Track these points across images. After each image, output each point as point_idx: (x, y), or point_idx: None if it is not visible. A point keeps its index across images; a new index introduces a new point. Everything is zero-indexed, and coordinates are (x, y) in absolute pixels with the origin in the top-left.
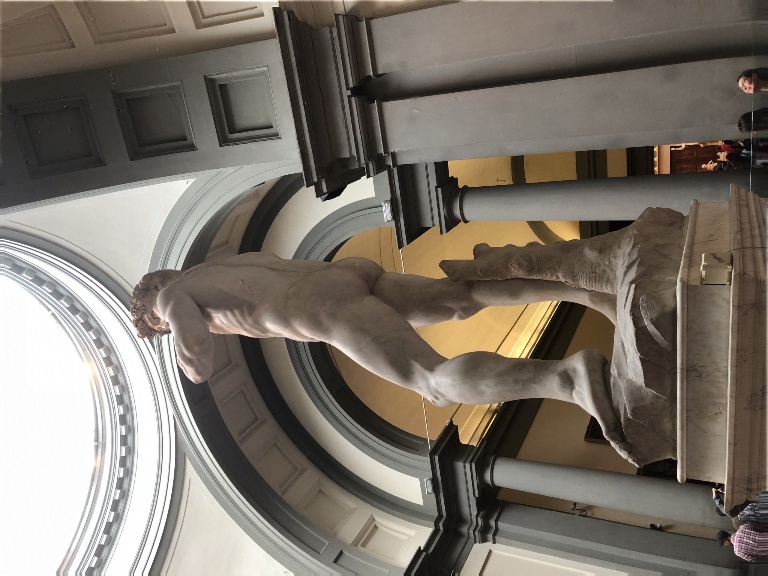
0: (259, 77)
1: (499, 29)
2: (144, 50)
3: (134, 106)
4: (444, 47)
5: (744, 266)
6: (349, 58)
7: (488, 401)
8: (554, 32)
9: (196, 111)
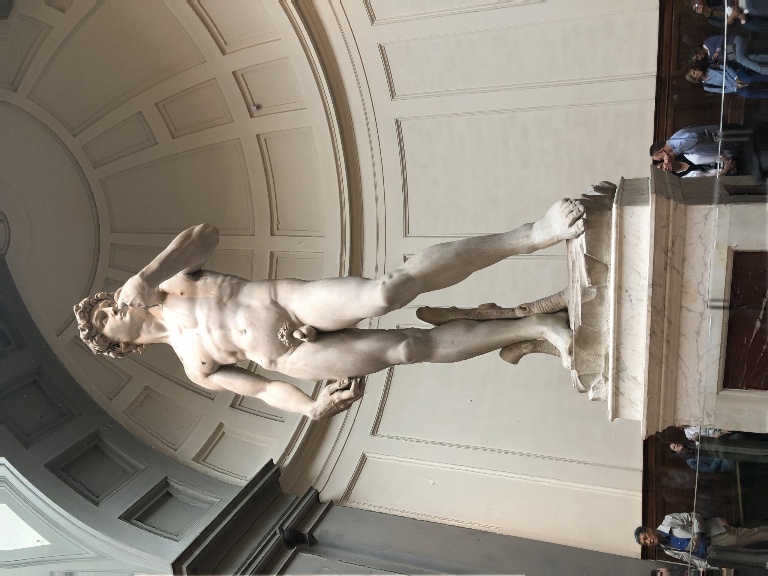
0: (204, 505)
1: (436, 543)
2: (145, 439)
3: (93, 453)
4: (383, 538)
5: None
6: (299, 512)
7: (450, 252)
8: (482, 558)
9: (132, 487)
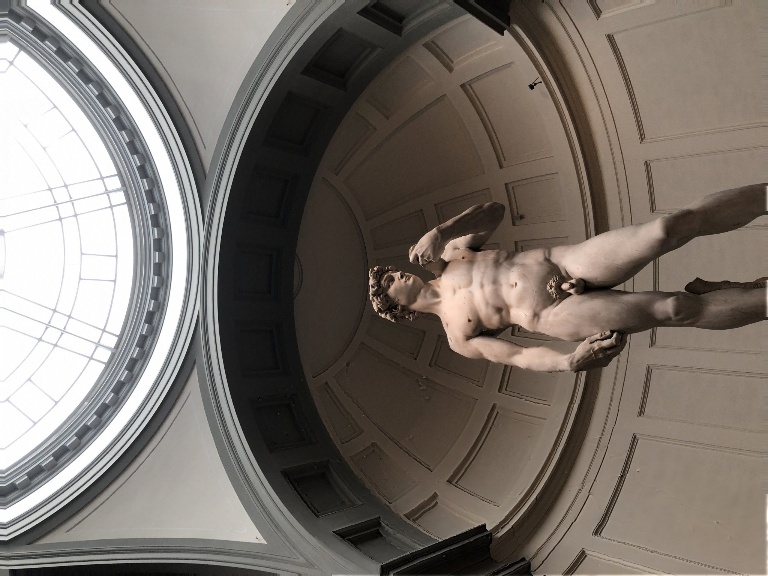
0: None
1: None
2: (365, 484)
3: (320, 479)
4: None
5: None
6: (509, 572)
7: None
8: None
9: (349, 514)
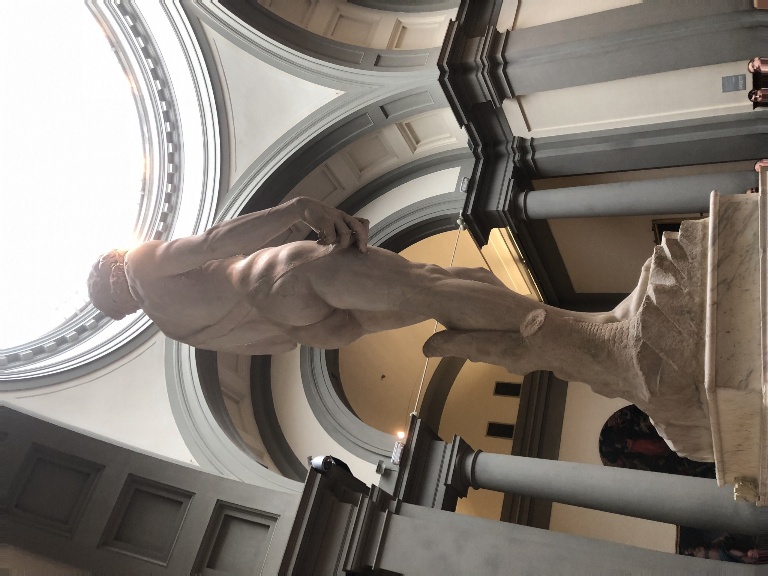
0: None
1: None
2: None
3: None
4: None
5: (767, 501)
6: None
7: None
8: None
9: None
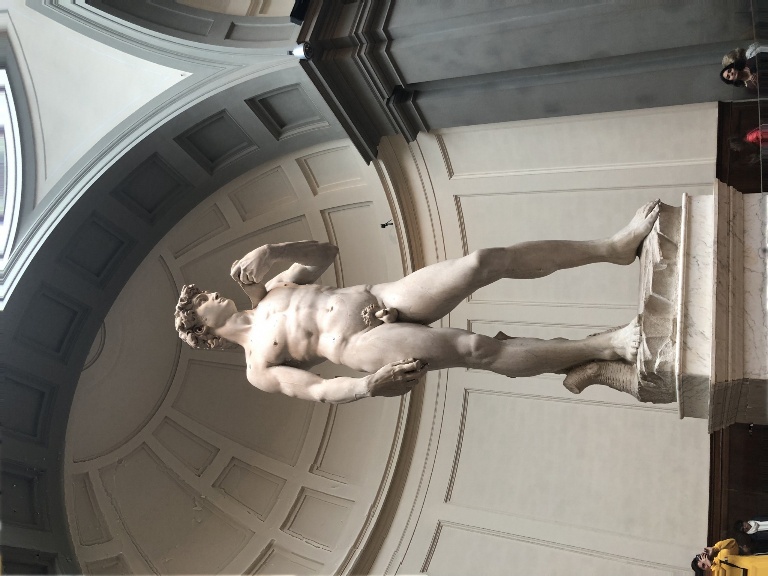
0: None
1: None
2: None
3: (37, 574)
4: None
5: None
6: None
7: None
8: None
9: None
